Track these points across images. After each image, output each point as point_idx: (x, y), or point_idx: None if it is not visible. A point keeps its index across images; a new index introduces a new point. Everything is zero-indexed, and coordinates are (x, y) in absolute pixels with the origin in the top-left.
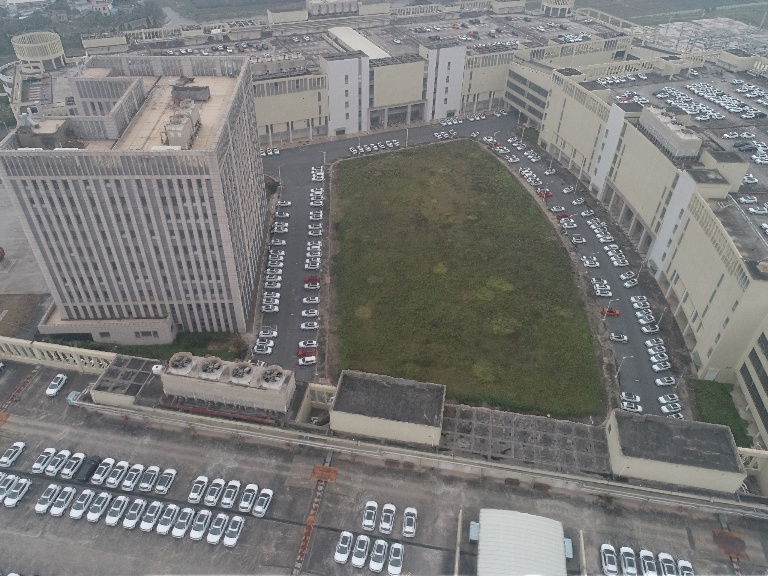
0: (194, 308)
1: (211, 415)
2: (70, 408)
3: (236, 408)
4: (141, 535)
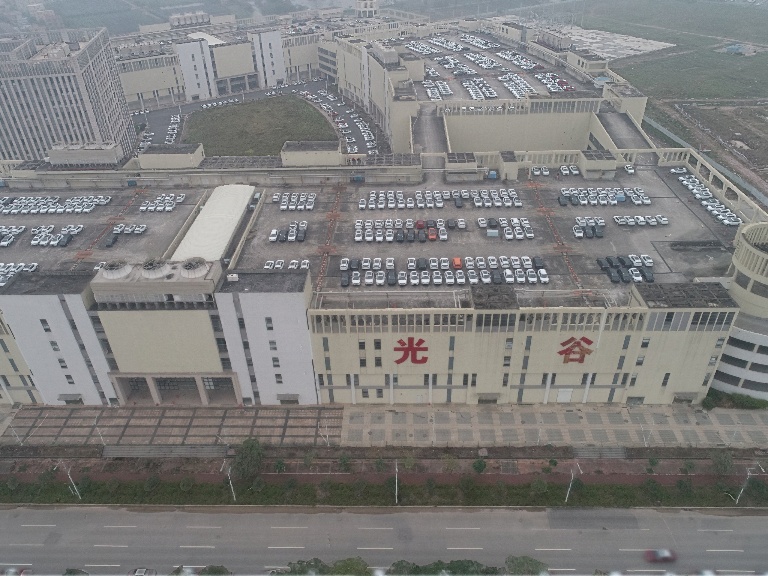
0: None
1: (77, 170)
2: None
3: (90, 166)
4: (40, 215)
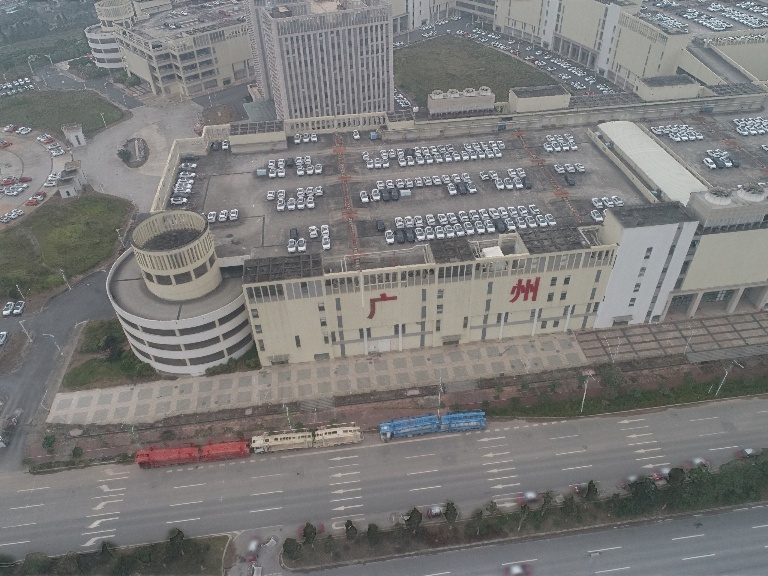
0: (367, 122)
1: (458, 118)
2: (372, 141)
3: (468, 113)
4: (457, 163)
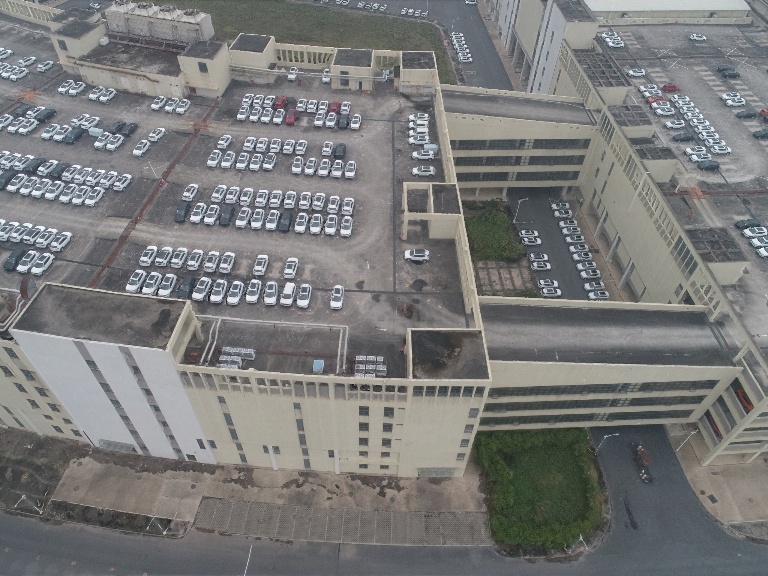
0: None
1: None
2: None
3: None
4: None
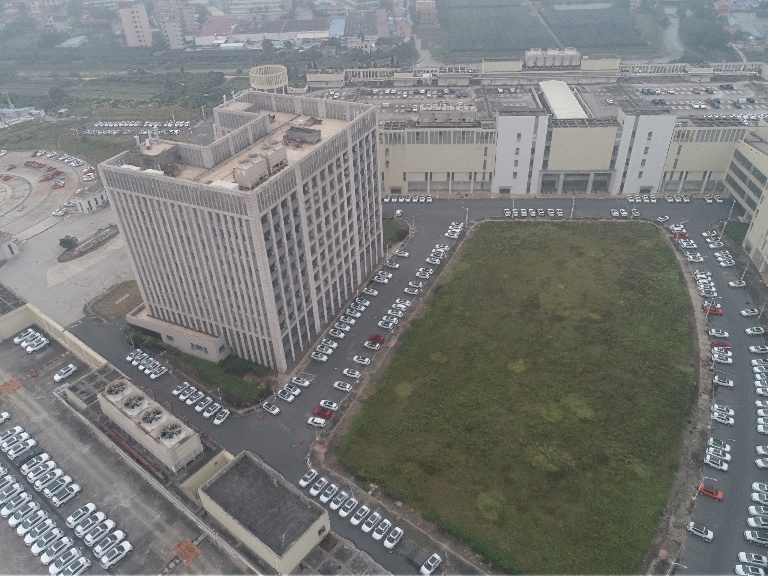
0: (241, 336)
1: (123, 448)
2: None
3: None
4: (15, 536)
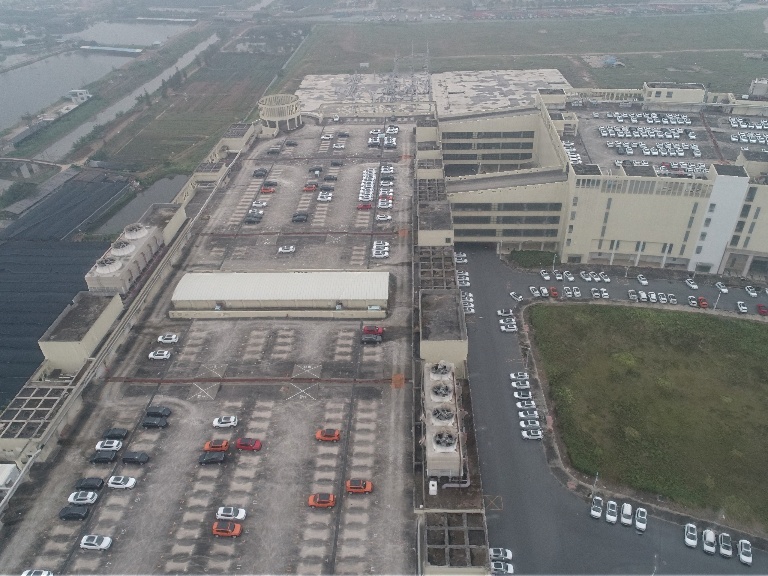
0: None
1: None
2: None
3: None
4: None
